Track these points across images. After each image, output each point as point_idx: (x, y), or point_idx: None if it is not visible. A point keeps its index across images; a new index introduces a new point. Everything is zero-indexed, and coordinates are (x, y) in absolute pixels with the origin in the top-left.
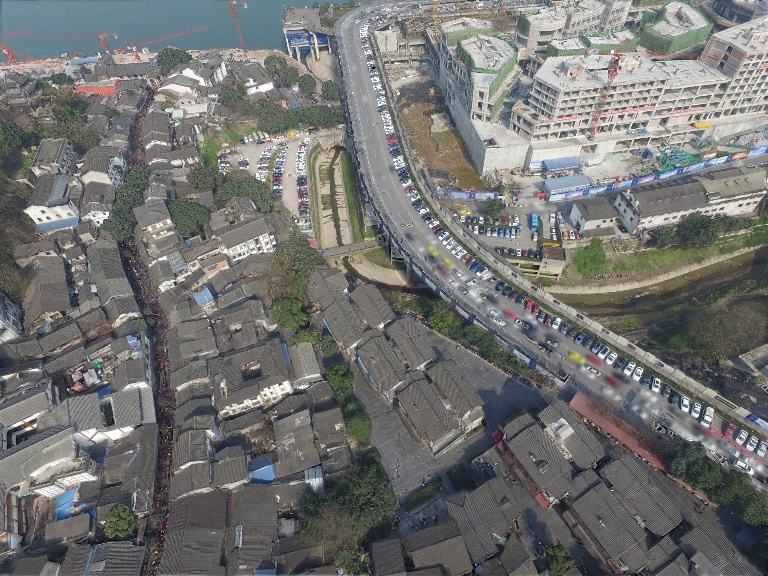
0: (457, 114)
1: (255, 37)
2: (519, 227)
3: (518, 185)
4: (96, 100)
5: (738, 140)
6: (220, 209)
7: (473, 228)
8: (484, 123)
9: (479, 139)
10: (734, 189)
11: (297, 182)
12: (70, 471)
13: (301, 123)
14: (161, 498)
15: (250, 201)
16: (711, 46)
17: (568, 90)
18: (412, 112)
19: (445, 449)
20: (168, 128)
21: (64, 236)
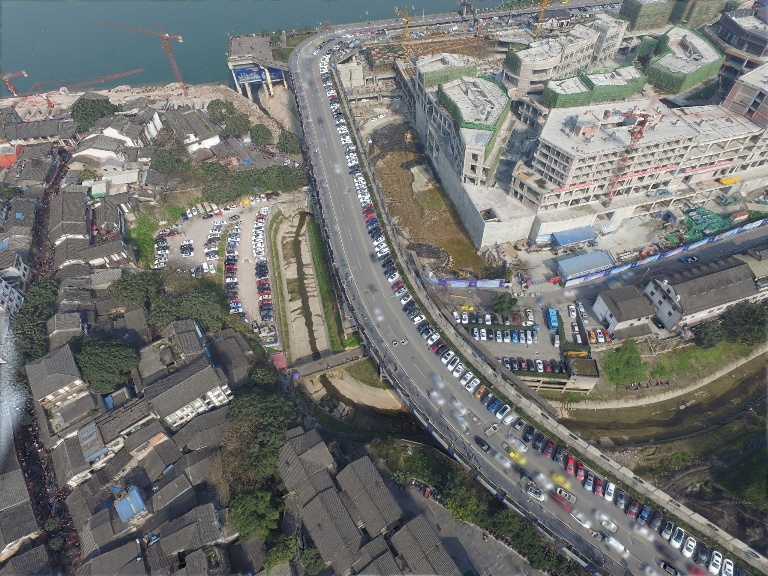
0: (442, 170)
1: (197, 67)
2: (535, 328)
3: (525, 265)
4: None
5: None
6: (153, 342)
7: (479, 332)
8: (478, 187)
9: (475, 209)
10: None
11: (256, 271)
12: None
13: (256, 187)
14: None
15: (194, 325)
16: (737, 91)
17: (584, 156)
18: (388, 164)
19: None
20: (85, 212)
21: None
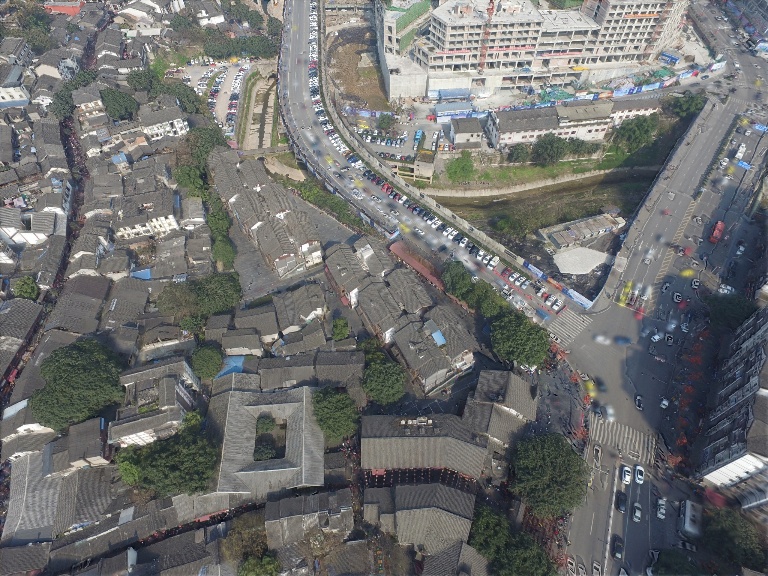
0: (380, 52)
1: None
2: (404, 139)
3: (416, 109)
4: (62, 18)
5: (610, 84)
6: (149, 102)
7: (367, 138)
8: (395, 56)
9: (387, 69)
10: (582, 115)
11: (230, 98)
12: None
13: (244, 52)
14: (63, 285)
15: (176, 99)
16: None
17: (454, 24)
18: (346, 50)
19: (288, 273)
20: (120, 43)
21: (14, 111)
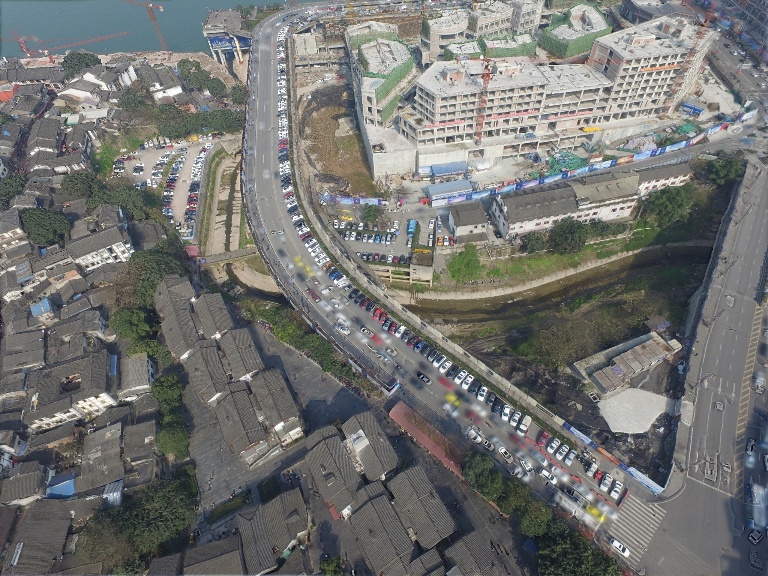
0: (360, 118)
1: (187, 39)
2: (395, 233)
3: (406, 190)
4: None
5: (627, 144)
6: (85, 217)
7: (351, 234)
8: (377, 128)
9: (369, 144)
10: (604, 194)
11: (189, 188)
12: None
13: (205, 128)
14: None
15: (118, 209)
16: (595, 50)
17: (444, 95)
18: (321, 116)
19: (260, 461)
20: (58, 134)
21: None
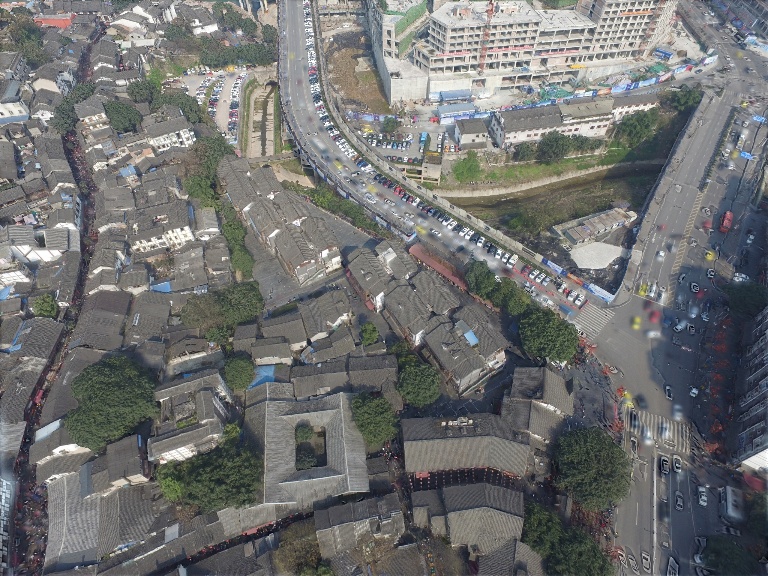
0: (377, 56)
1: None
2: (410, 141)
3: (418, 112)
4: (53, 31)
5: (607, 80)
6: (152, 113)
7: (372, 142)
8: (394, 60)
9: (387, 72)
10: (584, 112)
11: (230, 106)
12: (7, 269)
13: (240, 60)
14: (81, 302)
15: (179, 109)
16: None
17: (454, 27)
18: (342, 55)
19: (309, 280)
20: (116, 55)
21: (15, 127)
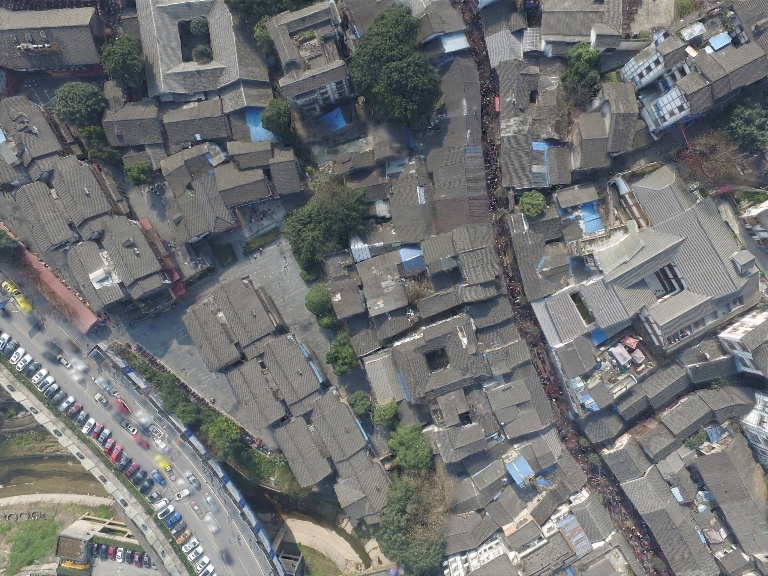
0: None
1: None
2: None
3: None
4: None
5: None
6: None
7: None
8: None
9: None
10: None
11: None
12: (593, 240)
13: None
14: (507, 235)
15: None
16: None
17: None
18: None
19: None
20: None
21: None
